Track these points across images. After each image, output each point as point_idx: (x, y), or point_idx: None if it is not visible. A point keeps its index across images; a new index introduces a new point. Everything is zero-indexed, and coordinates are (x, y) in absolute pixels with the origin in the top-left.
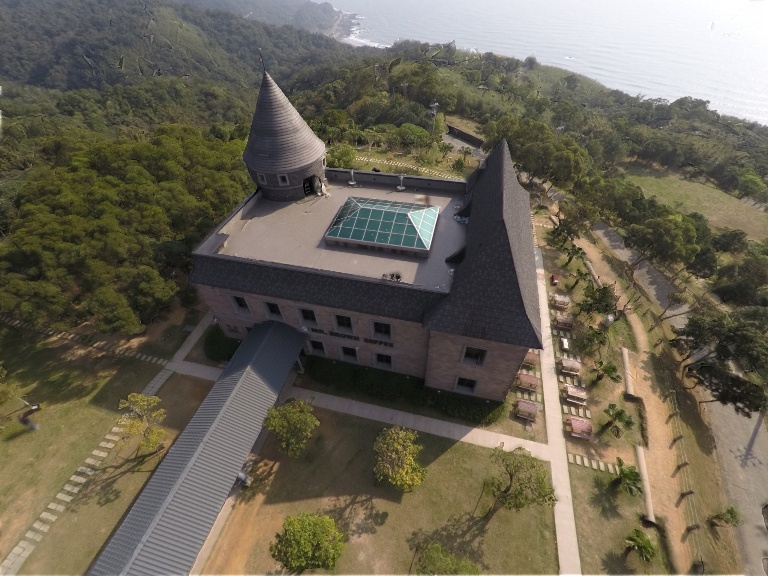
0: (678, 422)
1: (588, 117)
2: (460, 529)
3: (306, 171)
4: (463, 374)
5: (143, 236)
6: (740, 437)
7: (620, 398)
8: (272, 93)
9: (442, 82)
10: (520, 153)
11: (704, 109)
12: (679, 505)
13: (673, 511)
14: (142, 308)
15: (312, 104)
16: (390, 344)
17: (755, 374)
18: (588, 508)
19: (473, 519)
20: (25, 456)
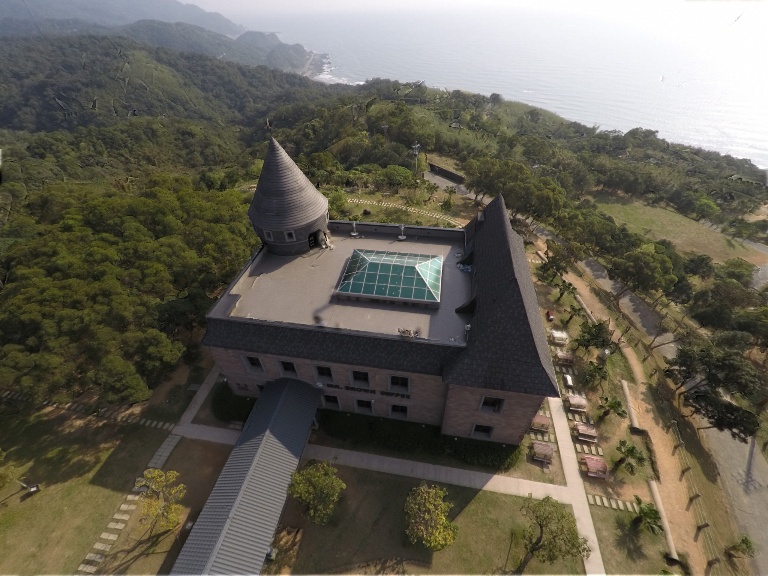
0: (684, 453)
1: (556, 151)
2: None
3: (312, 227)
4: (480, 421)
5: (147, 297)
6: (738, 460)
7: (627, 432)
8: (279, 157)
9: (419, 122)
10: (502, 192)
11: (655, 138)
12: (697, 539)
13: (693, 546)
14: (148, 372)
15: (291, 142)
16: (407, 396)
17: (741, 395)
18: (614, 551)
19: (506, 574)
20: (25, 547)
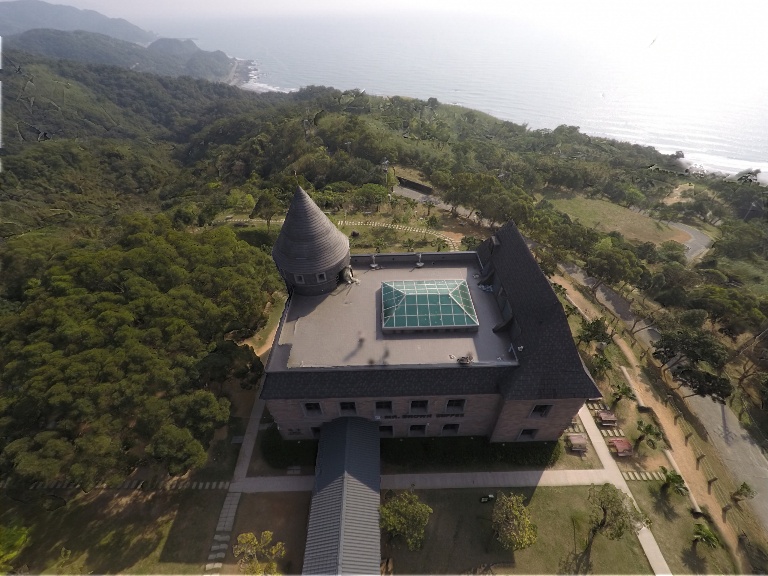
0: None
1: (504, 154)
2: (571, 569)
3: (340, 265)
4: (527, 426)
5: (181, 357)
6: (715, 418)
7: (636, 412)
8: (306, 203)
9: (378, 136)
10: (479, 203)
11: (578, 133)
12: (710, 492)
13: (709, 498)
14: (199, 435)
15: (239, 159)
16: (461, 415)
17: (704, 362)
18: (655, 516)
19: (577, 556)
20: None
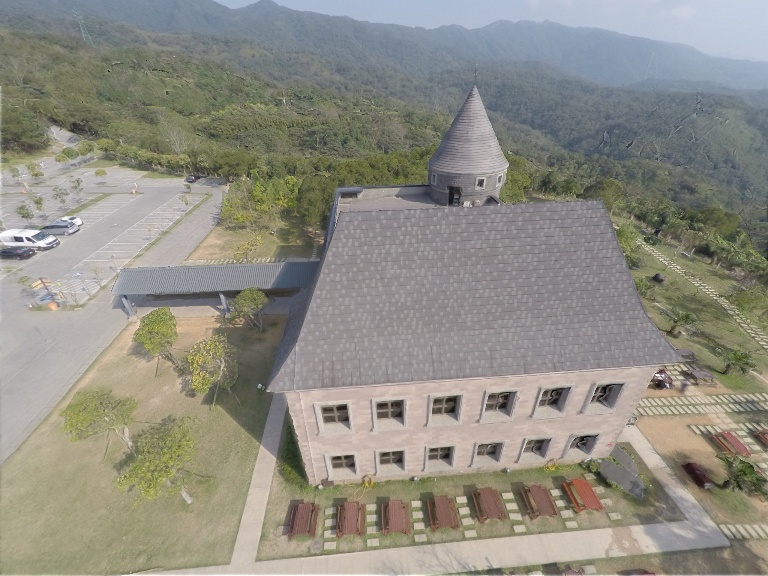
0: None
1: None
2: None
3: (452, 179)
4: None
5: None
6: None
7: None
8: (469, 103)
9: None
10: None
11: None
12: None
13: None
14: None
15: None
16: None
17: None
18: None
19: None
20: None
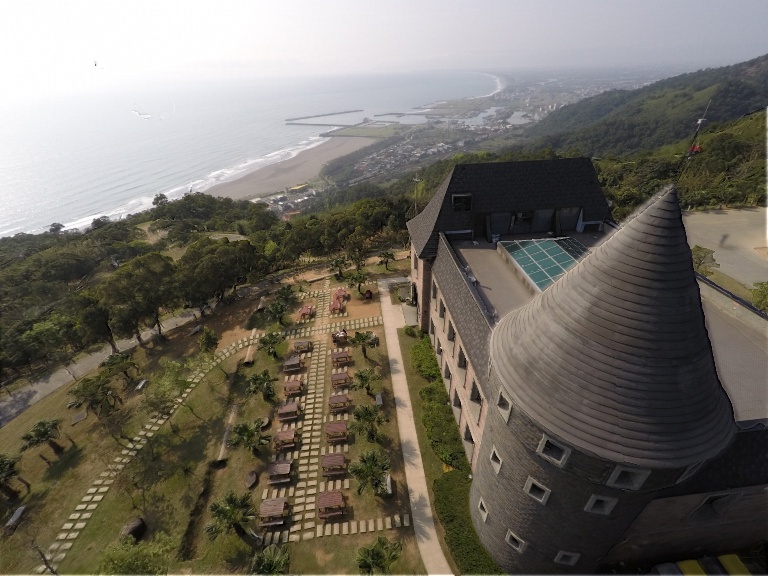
0: None
1: None
2: None
3: None
4: None
5: None
6: None
7: None
8: None
9: None
10: (189, 288)
11: None
12: None
13: None
14: None
15: None
16: None
17: None
18: None
19: None
20: None
